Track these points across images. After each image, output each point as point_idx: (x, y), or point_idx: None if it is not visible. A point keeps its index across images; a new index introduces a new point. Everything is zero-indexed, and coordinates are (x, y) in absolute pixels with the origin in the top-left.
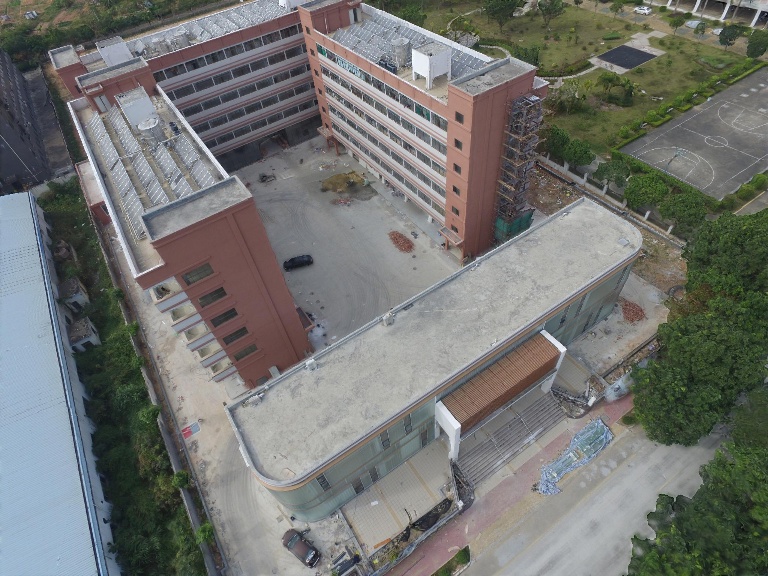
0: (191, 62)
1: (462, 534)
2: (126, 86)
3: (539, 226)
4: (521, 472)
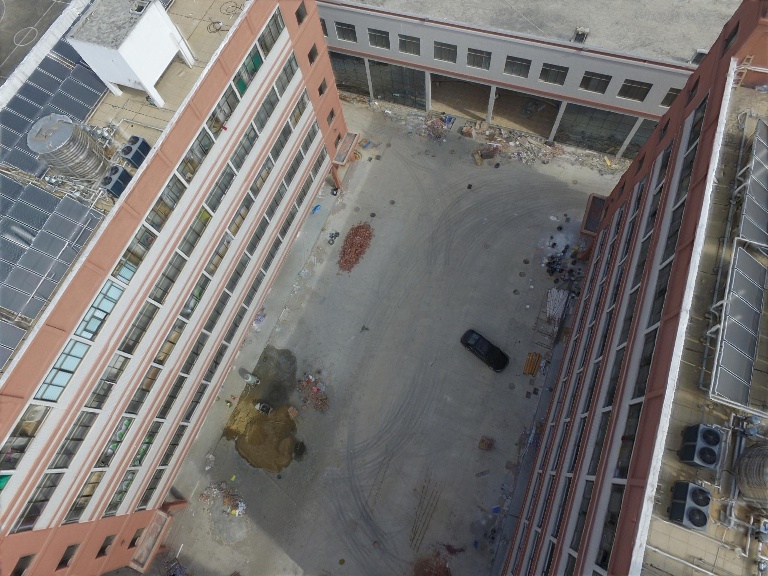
0: None
1: None
2: None
3: (334, 3)
4: None
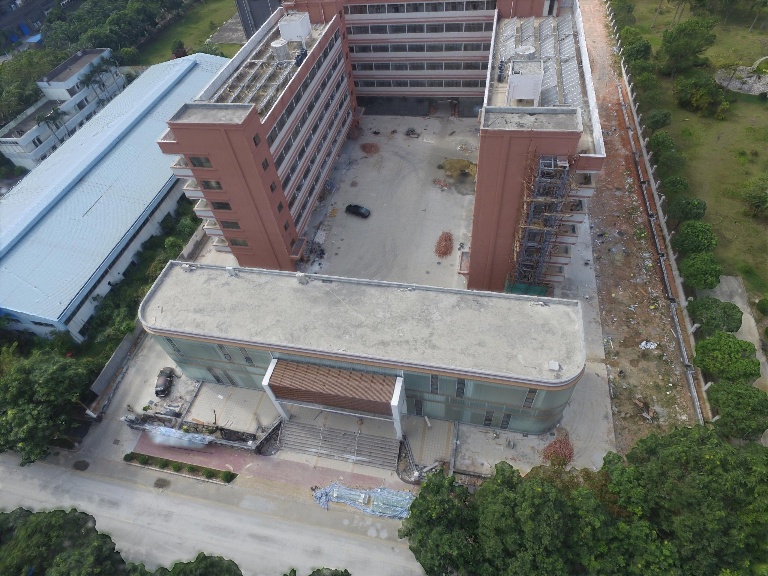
0: (393, 5)
1: (243, 465)
2: (313, 8)
3: (502, 296)
4: (319, 470)
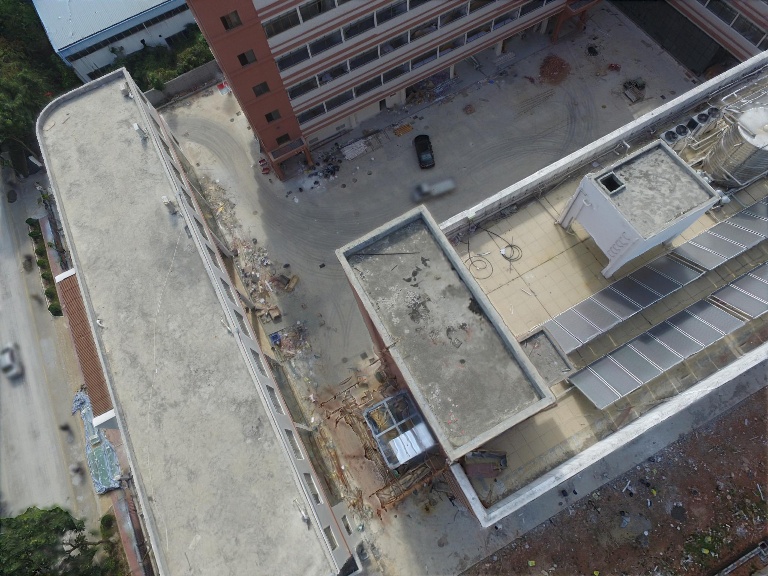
0: None
1: None
2: None
3: None
4: None
